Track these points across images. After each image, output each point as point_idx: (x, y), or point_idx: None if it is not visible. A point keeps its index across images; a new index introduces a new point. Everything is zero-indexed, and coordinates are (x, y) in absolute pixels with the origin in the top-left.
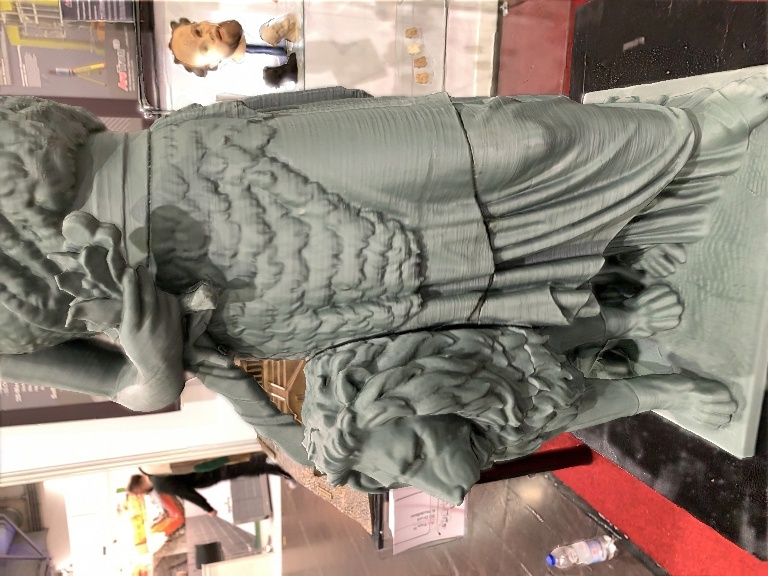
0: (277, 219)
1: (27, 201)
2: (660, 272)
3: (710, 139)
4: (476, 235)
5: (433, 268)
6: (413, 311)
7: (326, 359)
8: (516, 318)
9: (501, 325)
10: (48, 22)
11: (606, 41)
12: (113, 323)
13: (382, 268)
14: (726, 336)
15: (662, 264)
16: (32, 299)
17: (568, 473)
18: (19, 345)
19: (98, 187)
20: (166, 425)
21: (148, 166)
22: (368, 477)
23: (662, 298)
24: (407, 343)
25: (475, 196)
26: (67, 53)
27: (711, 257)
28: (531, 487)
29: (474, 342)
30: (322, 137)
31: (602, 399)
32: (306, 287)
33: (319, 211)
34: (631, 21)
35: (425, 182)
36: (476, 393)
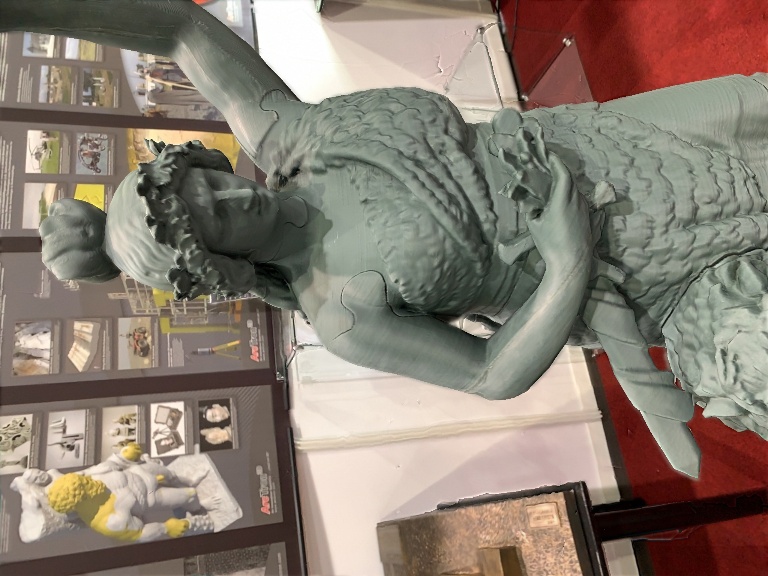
0: (631, 149)
1: (444, 130)
2: None
3: None
4: None
5: (767, 195)
6: None
7: (710, 273)
8: None
9: None
10: (194, 312)
11: None
12: (544, 199)
13: (731, 184)
14: None
15: None
16: (452, 208)
17: None
18: (431, 268)
19: (482, 136)
20: None
21: None
22: None
23: None
24: None
25: None
26: (208, 335)
27: None
28: None
29: None
30: (641, 97)
31: None
32: (675, 199)
33: (664, 139)
34: None
35: (740, 114)
36: None
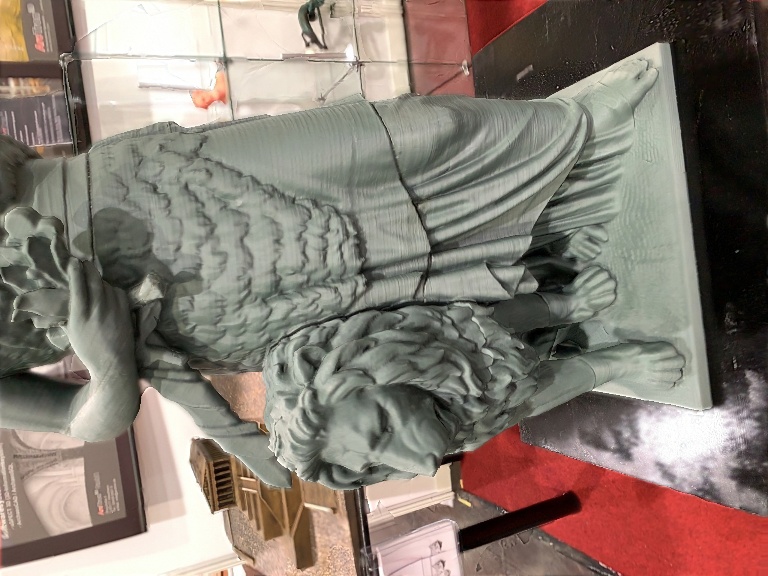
0: (216, 212)
1: None
2: (588, 255)
3: (601, 121)
4: (407, 215)
5: (372, 250)
6: (359, 290)
7: (281, 348)
8: (459, 294)
9: (447, 303)
10: None
11: (502, 77)
12: (60, 315)
13: (323, 250)
14: (659, 296)
15: (588, 246)
16: None
17: (561, 527)
18: None
19: (39, 198)
20: (132, 552)
21: (87, 176)
22: (340, 471)
23: (595, 276)
24: (358, 321)
25: (400, 179)
26: None
27: (628, 229)
28: (528, 554)
29: (422, 316)
30: (251, 136)
31: (559, 375)
32: (252, 274)
33: (256, 200)
34: (518, 55)
35: (351, 165)
36: (431, 358)
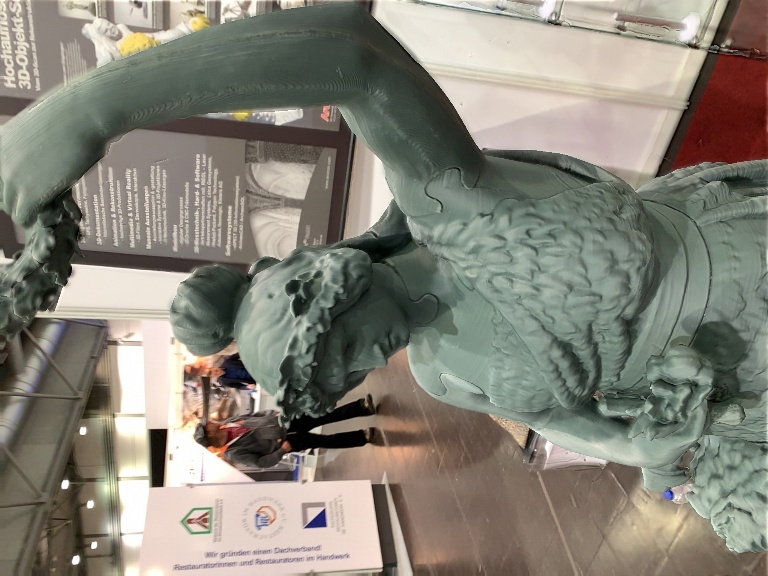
0: None
1: (618, 314)
2: None
3: None
4: None
5: None
6: None
7: None
8: None
9: None
10: None
11: None
12: None
13: None
14: None
15: None
16: (576, 390)
17: None
18: None
19: (662, 294)
20: None
21: (710, 277)
22: None
23: None
24: None
25: None
26: None
27: None
28: None
29: None
30: None
31: None
32: None
33: None
34: None
35: None
36: None
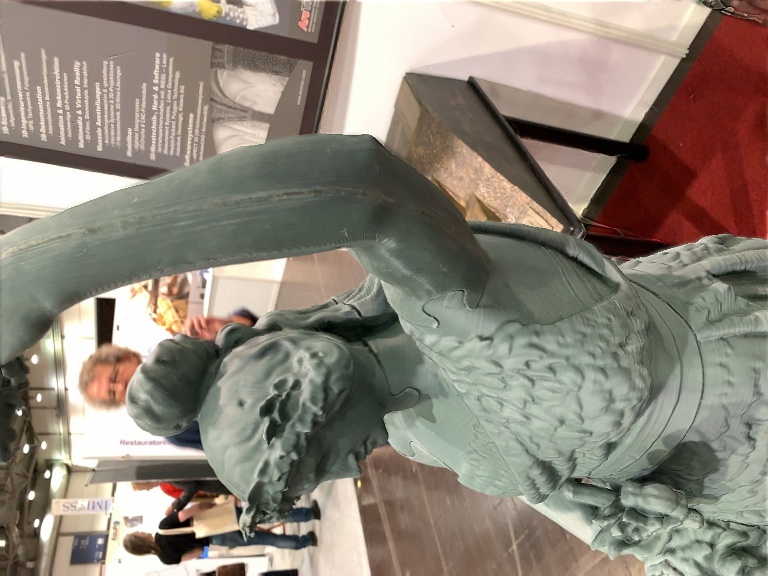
0: None
1: (604, 442)
2: None
3: None
4: None
5: None
6: None
7: (719, 532)
8: None
9: None
10: None
11: None
12: None
13: None
14: None
15: None
16: (547, 492)
17: None
18: None
19: (650, 415)
20: None
21: (700, 400)
22: None
23: None
24: None
25: None
26: None
27: None
28: None
29: None
30: None
31: None
32: (759, 505)
33: None
34: None
35: None
36: None
